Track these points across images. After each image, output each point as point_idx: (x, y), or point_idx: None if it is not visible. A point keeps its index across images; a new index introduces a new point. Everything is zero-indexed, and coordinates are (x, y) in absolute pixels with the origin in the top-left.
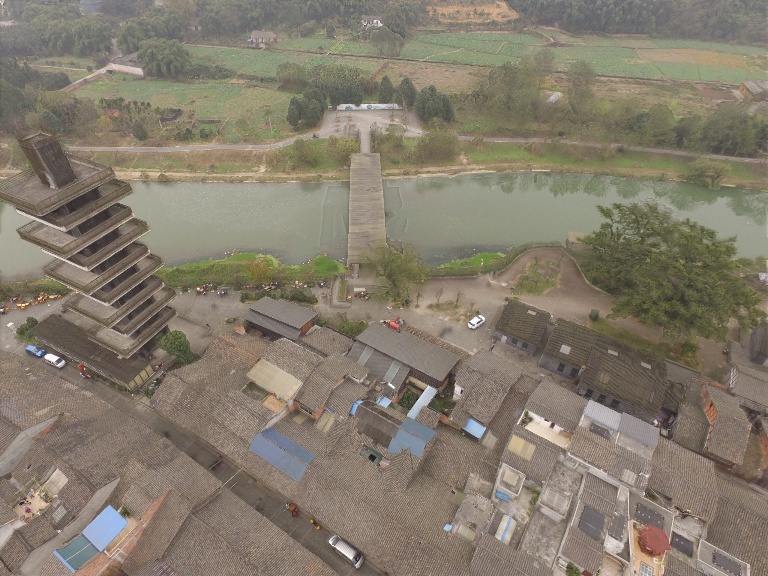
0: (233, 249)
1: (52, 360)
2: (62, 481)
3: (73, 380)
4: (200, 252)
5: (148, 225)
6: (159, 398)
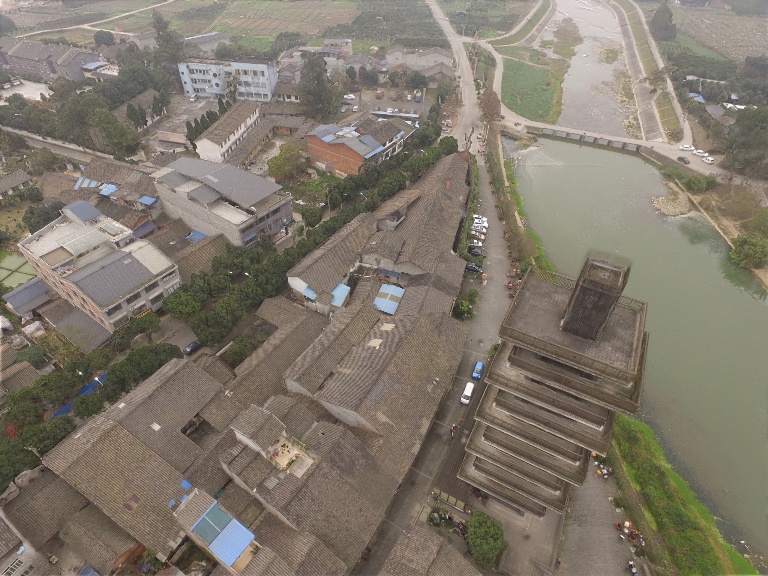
0: (760, 553)
1: (466, 391)
2: (300, 472)
3: (448, 420)
4: (722, 495)
5: (735, 399)
6: (412, 536)
